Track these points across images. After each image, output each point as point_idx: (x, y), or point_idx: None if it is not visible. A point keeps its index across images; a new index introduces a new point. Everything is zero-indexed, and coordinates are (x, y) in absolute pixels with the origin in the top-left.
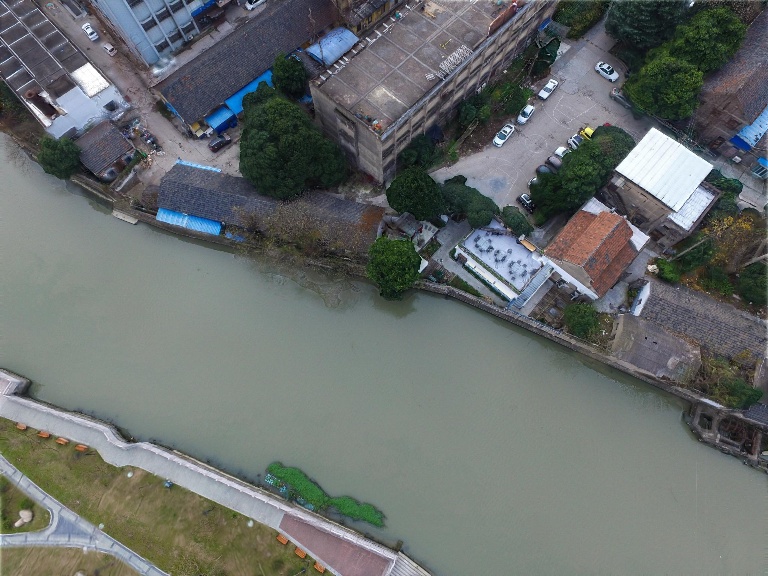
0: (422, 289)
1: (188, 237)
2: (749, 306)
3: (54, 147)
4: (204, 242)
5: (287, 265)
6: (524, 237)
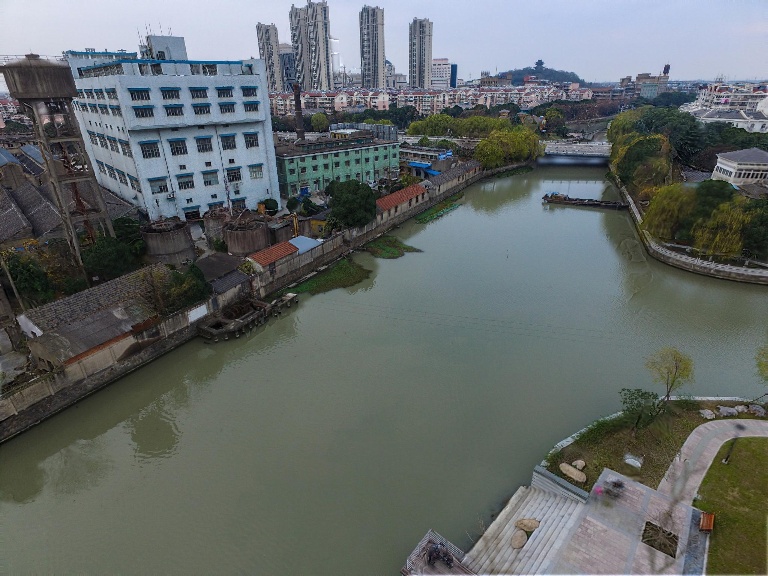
0: None
1: None
2: None
3: None
4: None
5: None
6: None
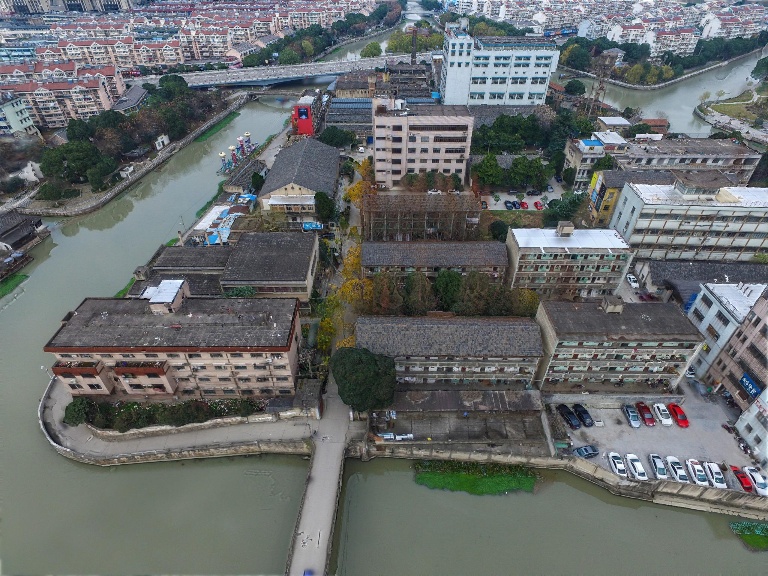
0: None
1: None
2: None
3: None
4: None
5: None
6: None
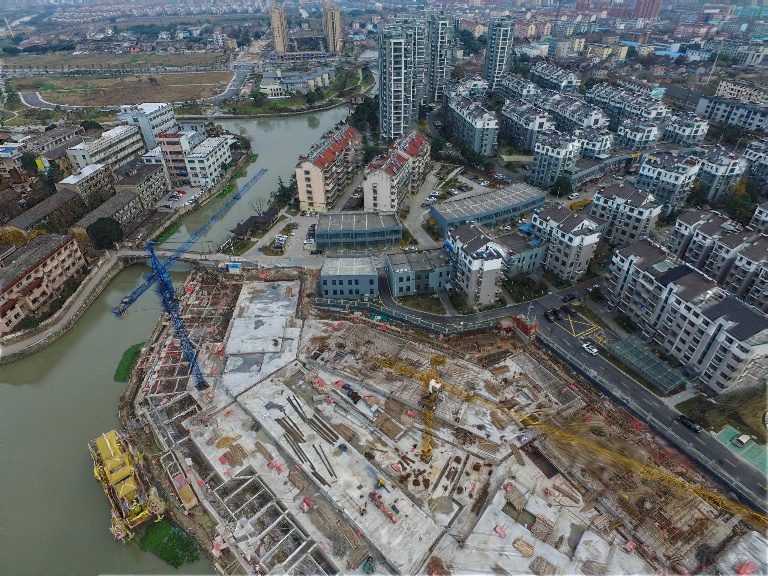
0: None
1: None
2: None
3: None
4: None
5: None
6: None
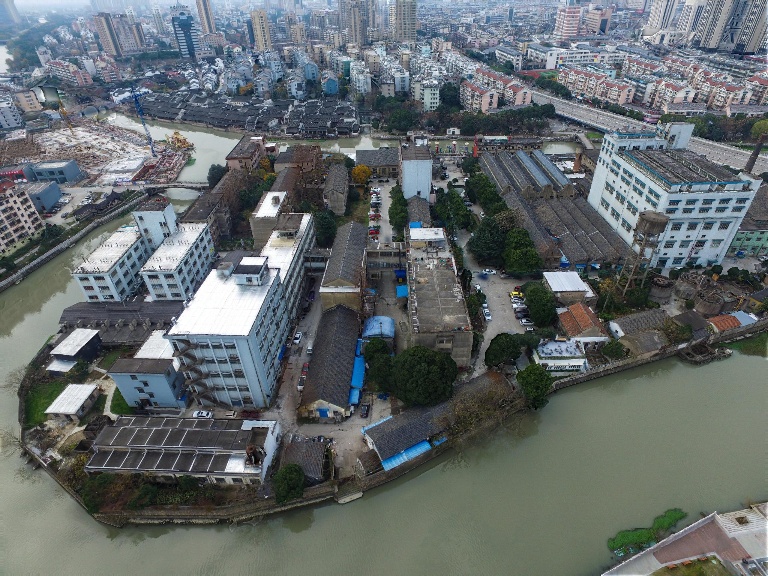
0: None
1: (403, 475)
2: (640, 310)
3: (291, 472)
4: (414, 471)
5: (495, 420)
6: None
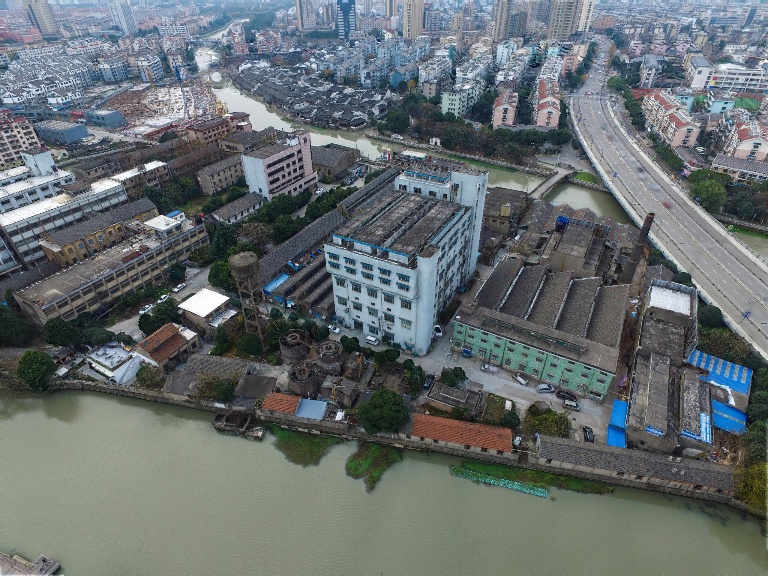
0: (67, 389)
1: None
2: (258, 359)
3: None
4: None
5: None
6: (123, 344)
